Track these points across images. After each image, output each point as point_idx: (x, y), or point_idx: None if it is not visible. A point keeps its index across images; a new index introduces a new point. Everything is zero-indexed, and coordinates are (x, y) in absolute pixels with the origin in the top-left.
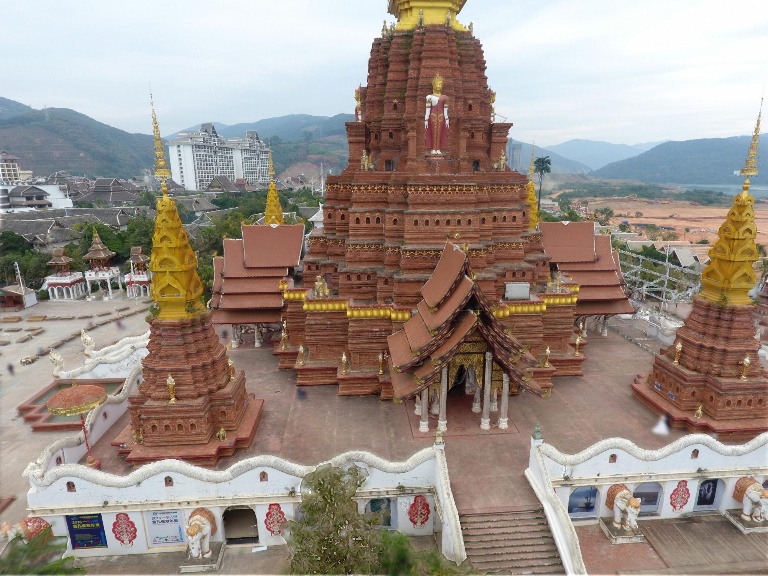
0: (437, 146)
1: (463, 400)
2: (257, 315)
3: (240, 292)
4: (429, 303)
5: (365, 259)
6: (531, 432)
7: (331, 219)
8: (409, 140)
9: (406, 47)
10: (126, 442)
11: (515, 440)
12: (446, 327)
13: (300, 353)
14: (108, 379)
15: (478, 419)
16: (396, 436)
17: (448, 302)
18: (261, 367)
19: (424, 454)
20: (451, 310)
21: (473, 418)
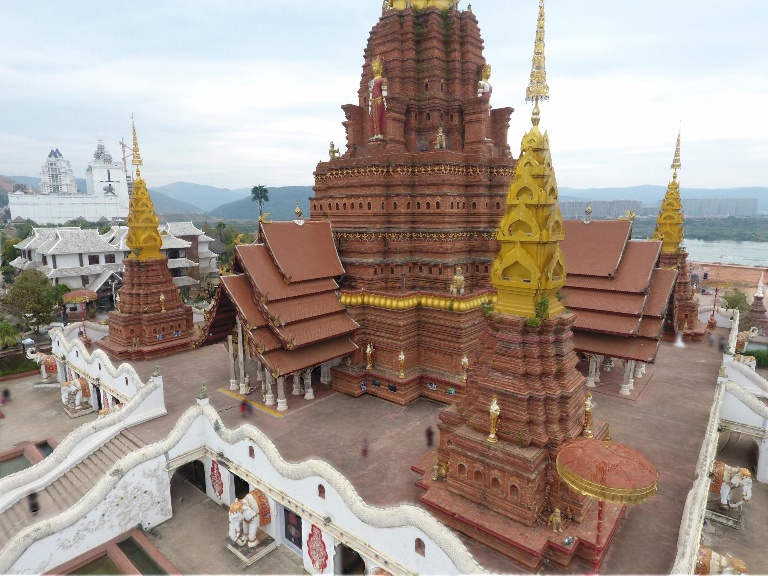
0: (485, 133)
1: (587, 367)
2: (326, 348)
3: (303, 318)
4: (594, 273)
5: (460, 249)
6: (657, 369)
7: (384, 210)
8: (476, 122)
9: (443, 27)
10: (549, 538)
11: (665, 376)
12: (650, 284)
13: (465, 366)
14: (59, 568)
15: (622, 374)
16: (626, 405)
17: (625, 266)
18: (380, 412)
19: (724, 390)
20: (646, 269)
21: (619, 374)
